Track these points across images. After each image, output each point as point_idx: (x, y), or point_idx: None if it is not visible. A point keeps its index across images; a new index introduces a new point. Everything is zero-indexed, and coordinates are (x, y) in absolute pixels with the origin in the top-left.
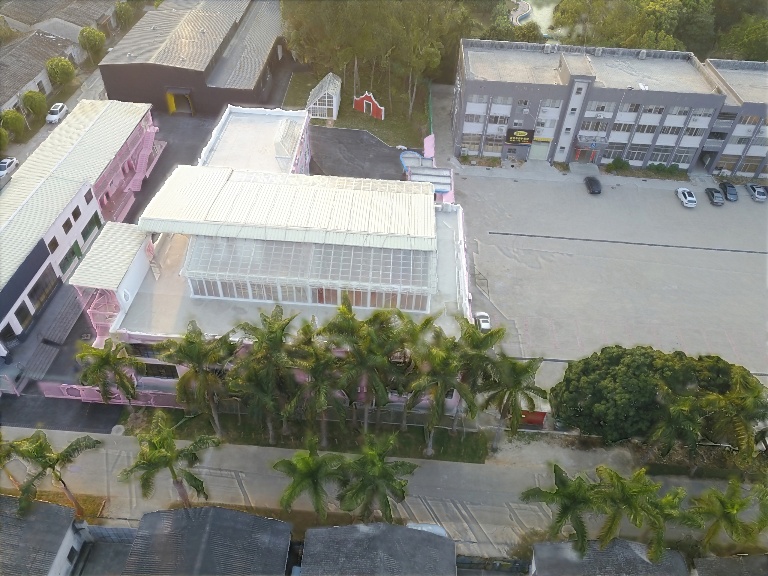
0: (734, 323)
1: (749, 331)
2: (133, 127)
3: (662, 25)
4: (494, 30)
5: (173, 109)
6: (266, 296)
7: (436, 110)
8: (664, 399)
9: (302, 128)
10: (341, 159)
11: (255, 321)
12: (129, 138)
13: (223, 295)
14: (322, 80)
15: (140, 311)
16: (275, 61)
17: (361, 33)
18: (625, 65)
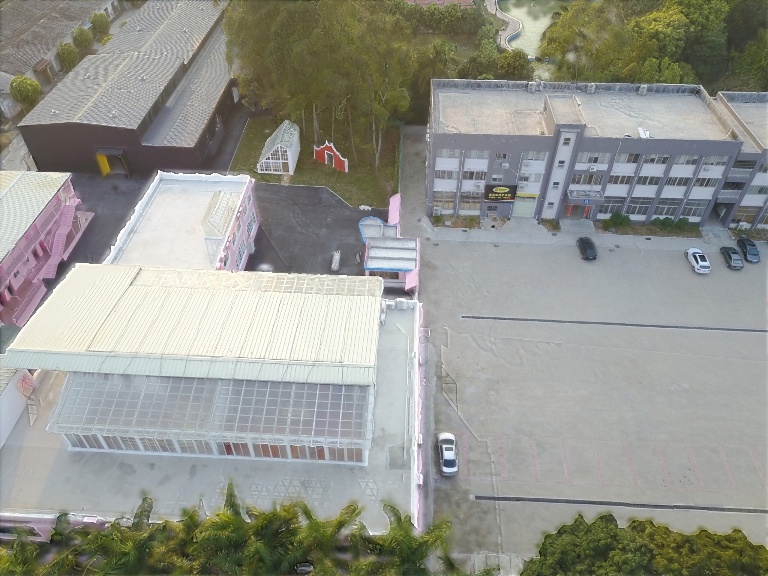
0: (760, 436)
1: None
2: (43, 205)
3: (666, 48)
4: (474, 62)
5: (107, 170)
6: (161, 448)
7: (409, 156)
8: None
9: (240, 199)
10: (294, 226)
11: (144, 485)
12: (40, 217)
13: (108, 447)
14: (277, 128)
15: (1, 474)
16: (229, 105)
17: (315, 78)
18: (622, 103)
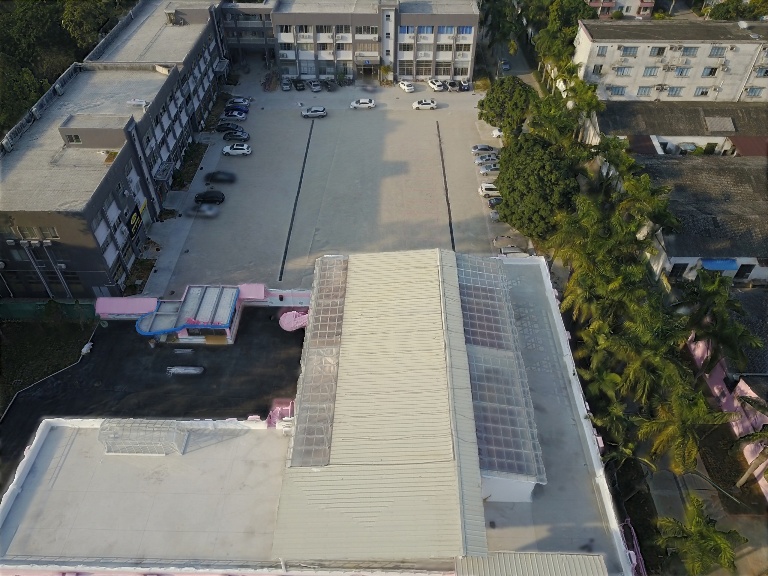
0: (395, 163)
1: (402, 159)
2: None
3: None
4: None
5: None
6: None
7: None
8: (575, 162)
9: None
10: None
11: (550, 423)
12: None
13: None
14: None
15: None
16: None
17: None
18: (72, 105)
